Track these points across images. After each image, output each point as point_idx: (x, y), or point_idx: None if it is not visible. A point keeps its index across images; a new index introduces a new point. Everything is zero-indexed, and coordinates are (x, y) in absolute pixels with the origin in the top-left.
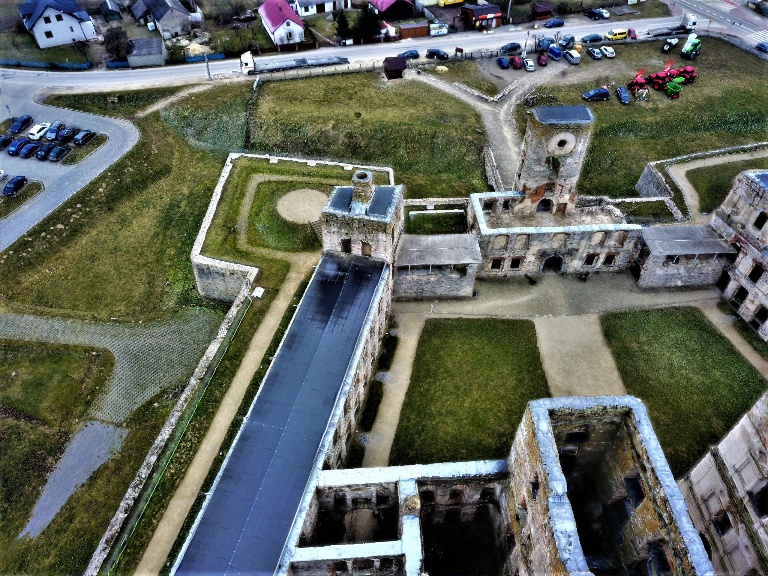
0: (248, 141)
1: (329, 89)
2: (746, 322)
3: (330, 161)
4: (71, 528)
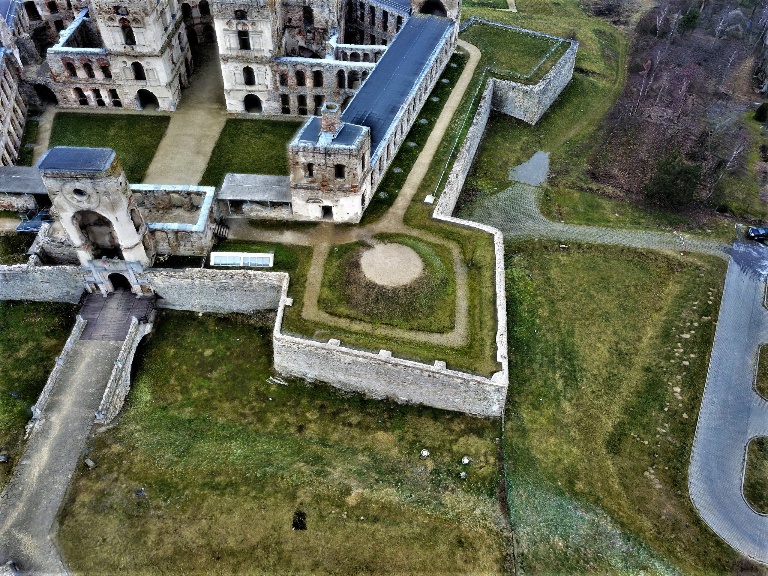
0: (502, 500)
1: None
2: None
3: (359, 455)
4: (520, 145)
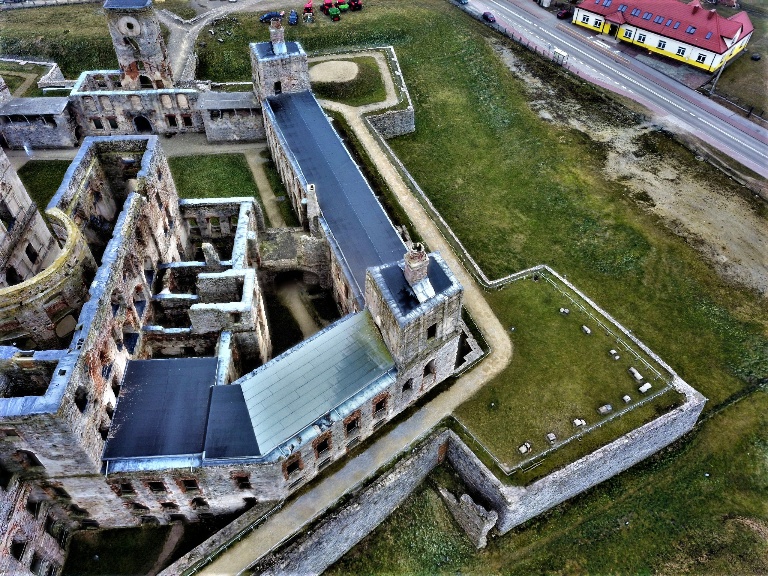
0: None
1: (55, 14)
2: (274, 162)
3: None
4: None
